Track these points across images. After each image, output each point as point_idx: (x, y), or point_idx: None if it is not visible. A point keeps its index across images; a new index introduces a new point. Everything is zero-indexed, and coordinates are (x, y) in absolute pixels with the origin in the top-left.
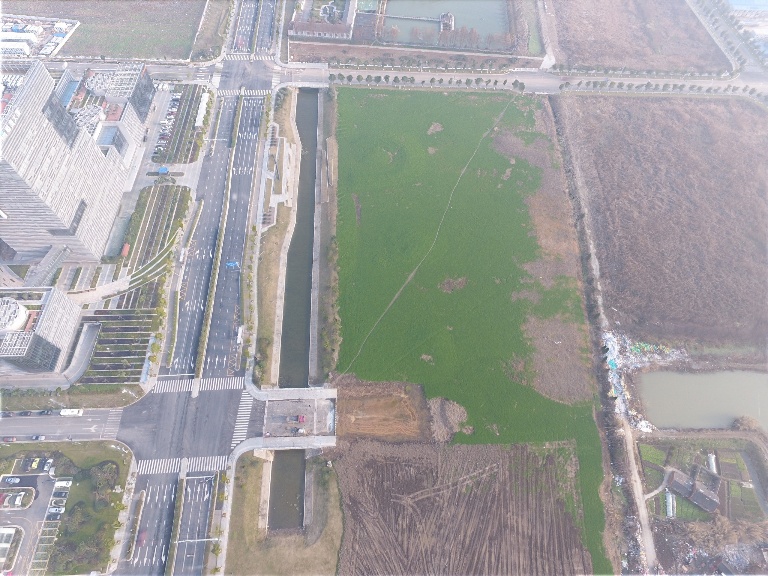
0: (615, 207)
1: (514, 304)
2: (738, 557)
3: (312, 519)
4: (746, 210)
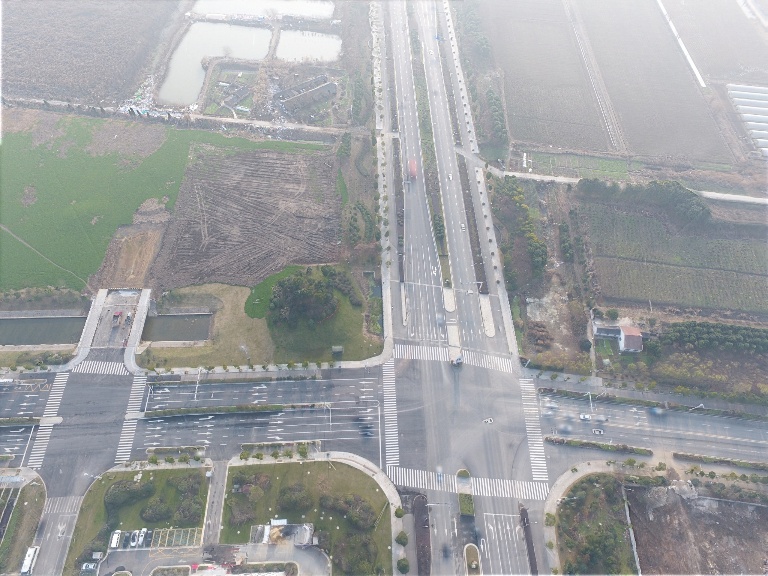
0: (4, 76)
1: (69, 157)
2: (274, 89)
3: (206, 307)
4: (50, 10)
